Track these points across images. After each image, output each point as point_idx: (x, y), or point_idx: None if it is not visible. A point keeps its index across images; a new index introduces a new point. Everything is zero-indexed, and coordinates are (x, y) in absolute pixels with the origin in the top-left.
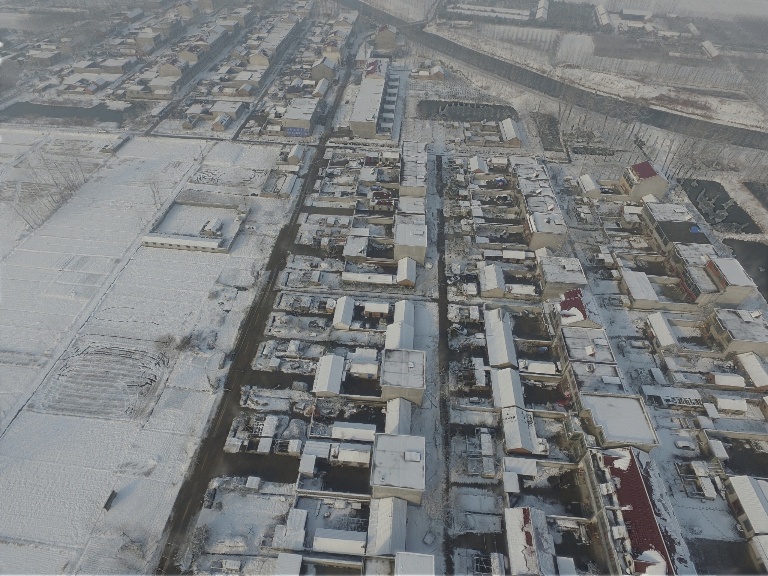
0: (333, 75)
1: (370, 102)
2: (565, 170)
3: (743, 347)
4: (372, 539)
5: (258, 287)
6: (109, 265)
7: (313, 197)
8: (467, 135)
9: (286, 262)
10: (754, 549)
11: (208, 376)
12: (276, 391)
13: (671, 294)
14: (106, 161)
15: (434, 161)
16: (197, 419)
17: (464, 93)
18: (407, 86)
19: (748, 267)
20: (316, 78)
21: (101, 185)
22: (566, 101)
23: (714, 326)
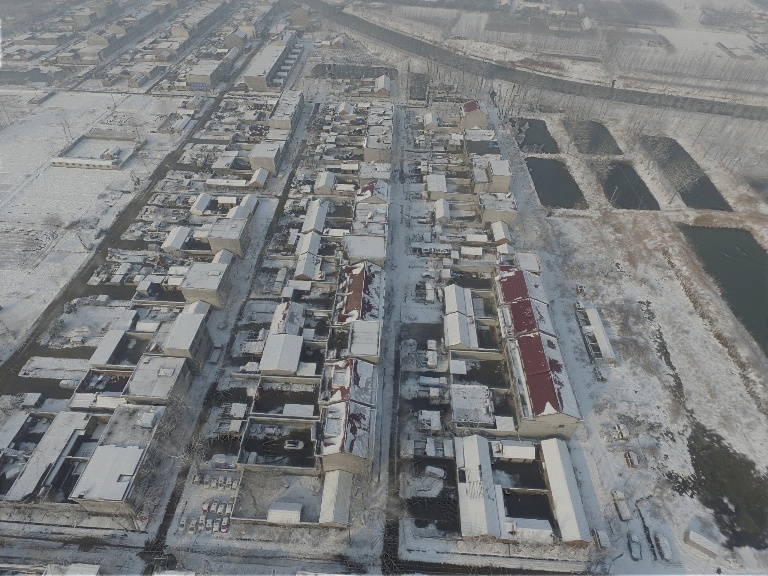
0: (243, 44)
1: (266, 62)
2: (420, 113)
3: (493, 217)
4: None
5: (139, 190)
6: (21, 179)
7: (201, 132)
8: (345, 88)
9: (166, 175)
10: None
11: (79, 236)
12: (136, 251)
13: (464, 191)
14: (32, 110)
15: (312, 107)
16: (71, 268)
17: (357, 58)
18: (309, 53)
19: (535, 174)
20: (229, 47)
21: (24, 126)
22: (443, 64)
23: (478, 205)
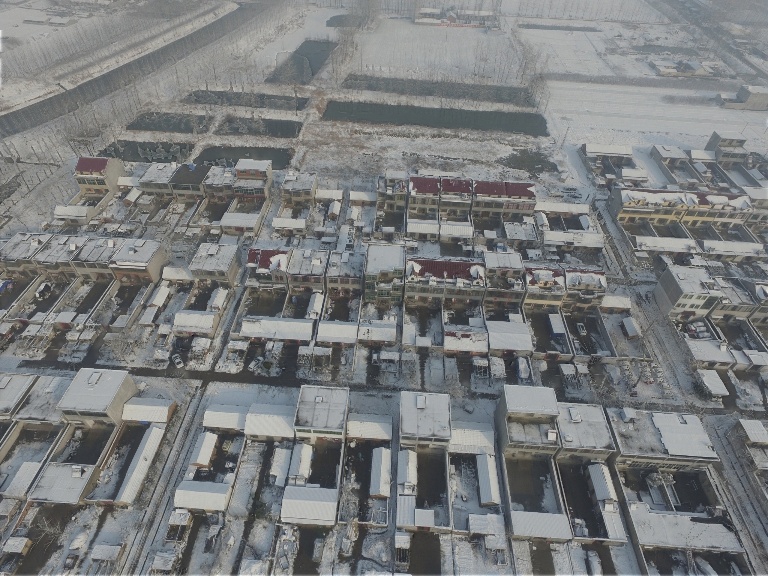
0: None
1: None
2: None
3: None
4: (482, 450)
5: None
6: None
7: None
8: None
9: None
10: (444, 240)
11: None
12: None
13: (248, 209)
14: None
15: None
16: None
17: None
18: None
19: (229, 164)
20: None
21: None
22: None
23: (293, 196)
